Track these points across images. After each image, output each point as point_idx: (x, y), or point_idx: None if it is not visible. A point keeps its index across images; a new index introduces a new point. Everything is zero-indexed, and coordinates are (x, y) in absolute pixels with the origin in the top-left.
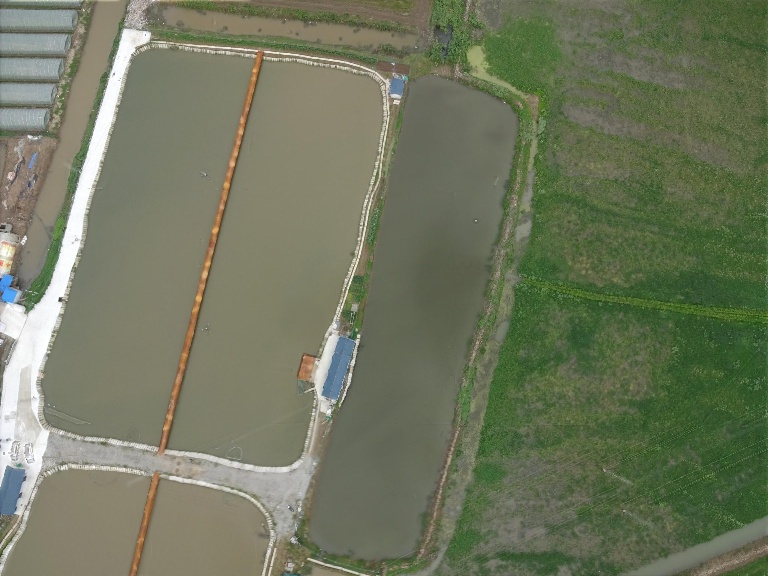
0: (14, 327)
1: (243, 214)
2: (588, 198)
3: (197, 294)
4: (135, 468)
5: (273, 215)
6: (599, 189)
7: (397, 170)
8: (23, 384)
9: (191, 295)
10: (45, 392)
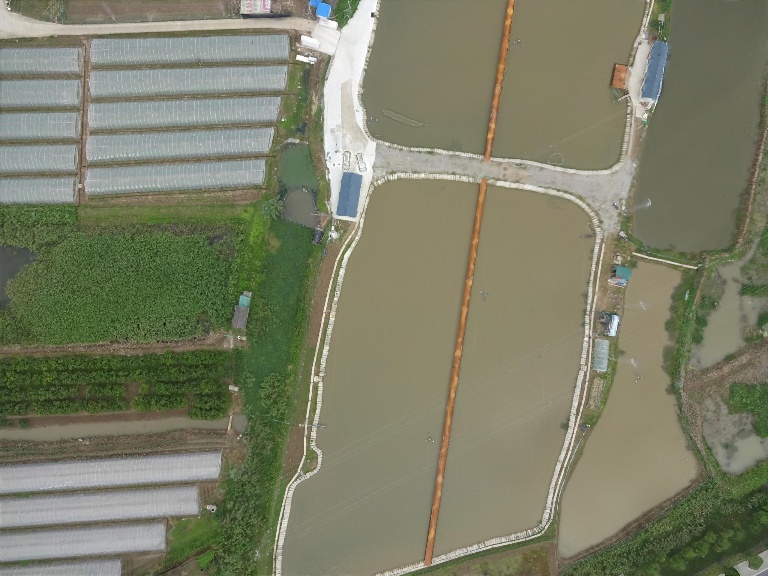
0: (328, 44)
1: None
2: None
3: (508, 7)
4: (463, 175)
5: None
6: None
7: None
8: (345, 98)
9: (501, 9)
10: (366, 106)
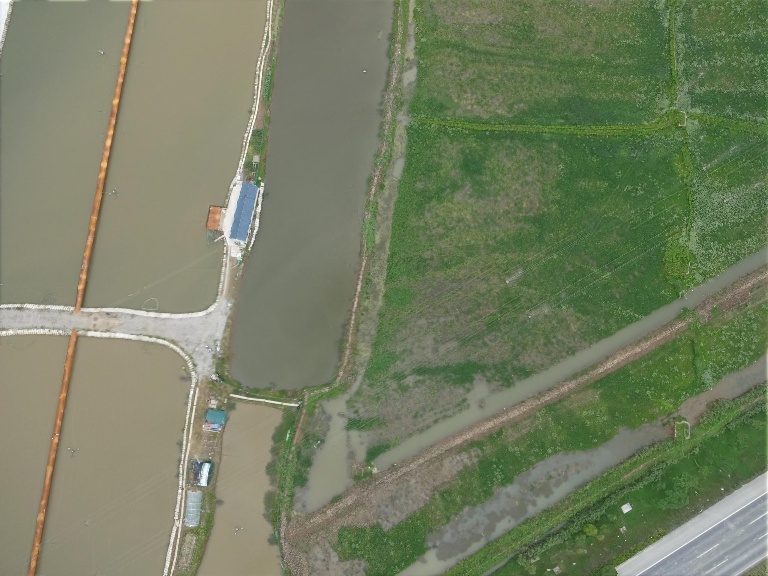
0: None
1: (142, 85)
2: (466, 42)
3: (102, 161)
4: (52, 328)
5: (171, 83)
6: (476, 33)
7: (286, 33)
8: None
9: (96, 163)
10: None
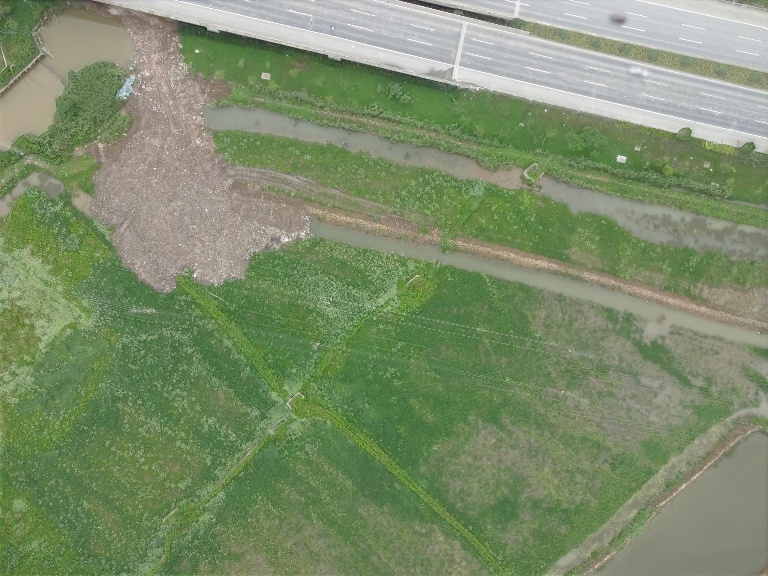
0: None
1: None
2: None
3: None
4: None
5: None
6: None
7: None
8: None
9: None
10: None
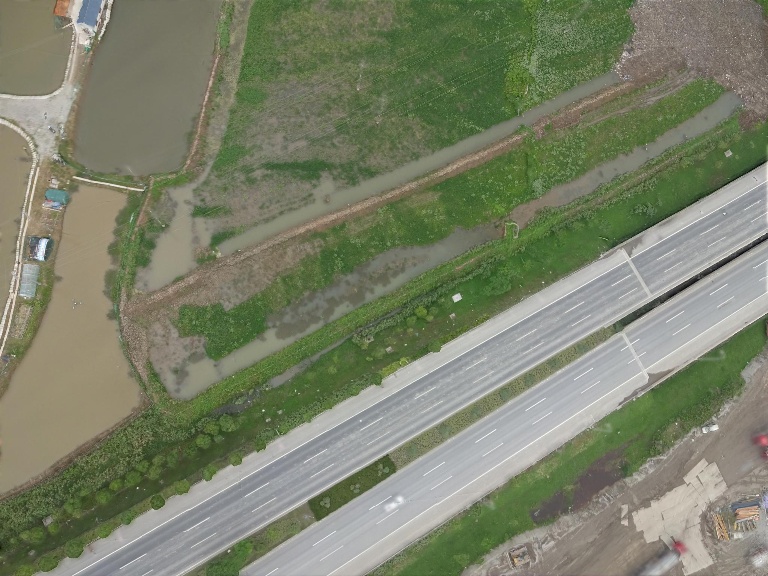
0: None
1: None
2: None
3: None
4: None
5: None
6: None
7: None
8: None
9: None
10: None
